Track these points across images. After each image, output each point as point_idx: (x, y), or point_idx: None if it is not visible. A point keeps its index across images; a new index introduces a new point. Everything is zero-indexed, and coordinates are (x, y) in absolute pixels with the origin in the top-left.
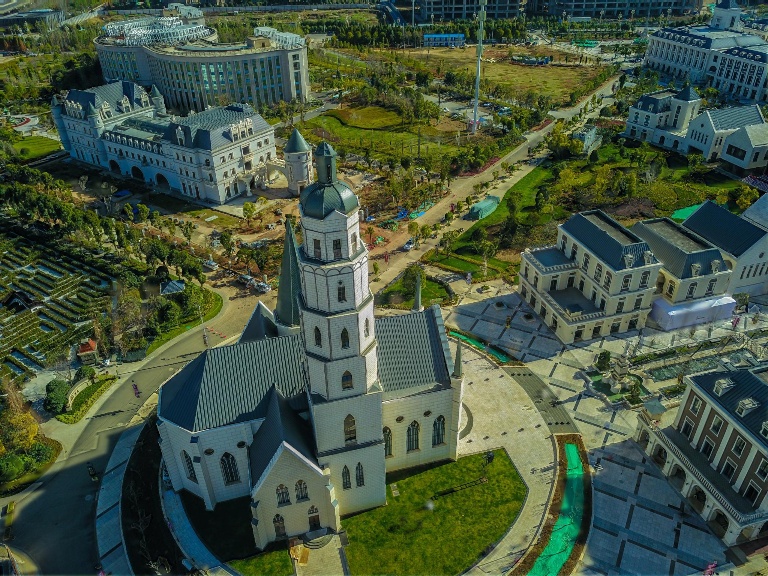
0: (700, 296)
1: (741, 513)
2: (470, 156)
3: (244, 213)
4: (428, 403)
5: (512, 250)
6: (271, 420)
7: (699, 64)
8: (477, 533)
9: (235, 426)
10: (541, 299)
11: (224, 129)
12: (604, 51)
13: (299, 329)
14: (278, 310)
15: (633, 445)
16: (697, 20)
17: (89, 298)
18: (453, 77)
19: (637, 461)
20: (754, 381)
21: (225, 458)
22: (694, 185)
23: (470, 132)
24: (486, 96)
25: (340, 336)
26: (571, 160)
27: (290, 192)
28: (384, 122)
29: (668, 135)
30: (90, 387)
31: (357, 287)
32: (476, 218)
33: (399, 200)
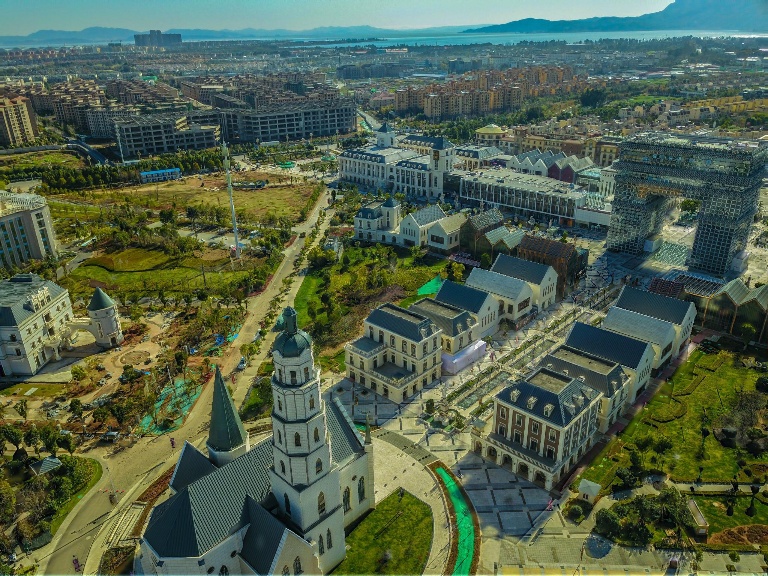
0: (466, 345)
1: (549, 467)
2: (252, 279)
3: (74, 377)
4: (354, 470)
5: (325, 347)
6: (259, 521)
7: (381, 174)
8: (415, 547)
9: (230, 539)
10: (370, 377)
11: (23, 302)
12: (304, 170)
13: (237, 450)
14: (213, 441)
15: (473, 454)
16: (360, 137)
17: None
18: (195, 211)
19: (480, 463)
20: (529, 386)
21: (220, 572)
22: (421, 268)
23: (235, 257)
24: (231, 223)
25: (313, 434)
26: (328, 266)
27: (101, 346)
28: (151, 262)
29: (387, 234)
30: None
31: (319, 396)
32: (283, 329)
33: (210, 329)
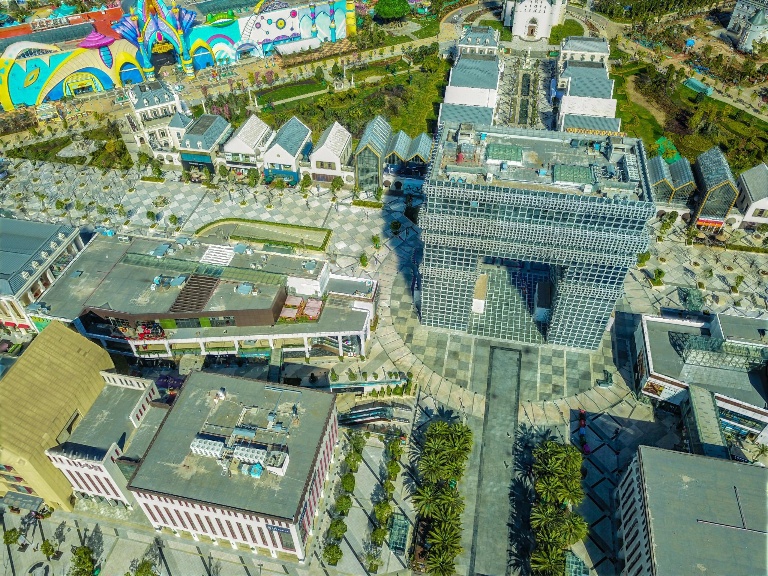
0: None
1: None
2: None
3: None
4: None
5: None
6: None
7: None
8: None
9: None
10: None
11: None
12: None
13: None
14: None
15: None
16: None
17: (635, 3)
18: None
19: None
20: None
21: None
22: None
23: None
24: None
25: None
26: None
27: None
28: None
29: None
30: (580, 4)
31: None
32: None
33: None
